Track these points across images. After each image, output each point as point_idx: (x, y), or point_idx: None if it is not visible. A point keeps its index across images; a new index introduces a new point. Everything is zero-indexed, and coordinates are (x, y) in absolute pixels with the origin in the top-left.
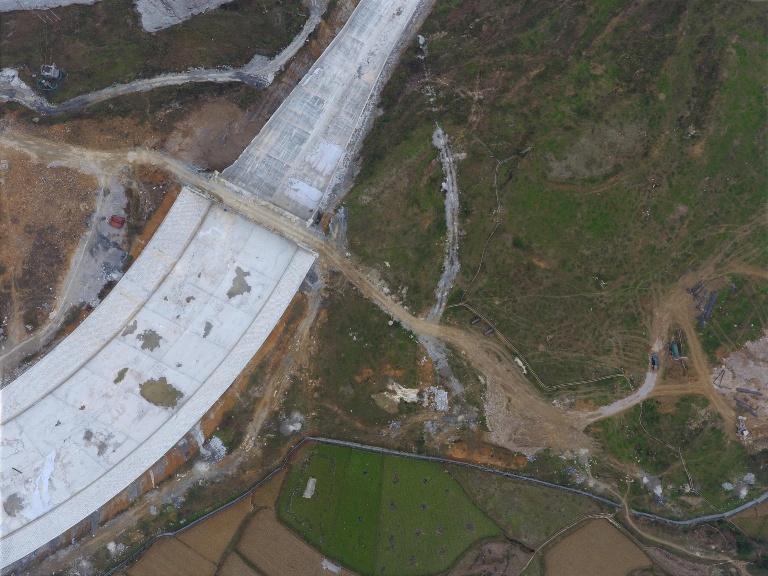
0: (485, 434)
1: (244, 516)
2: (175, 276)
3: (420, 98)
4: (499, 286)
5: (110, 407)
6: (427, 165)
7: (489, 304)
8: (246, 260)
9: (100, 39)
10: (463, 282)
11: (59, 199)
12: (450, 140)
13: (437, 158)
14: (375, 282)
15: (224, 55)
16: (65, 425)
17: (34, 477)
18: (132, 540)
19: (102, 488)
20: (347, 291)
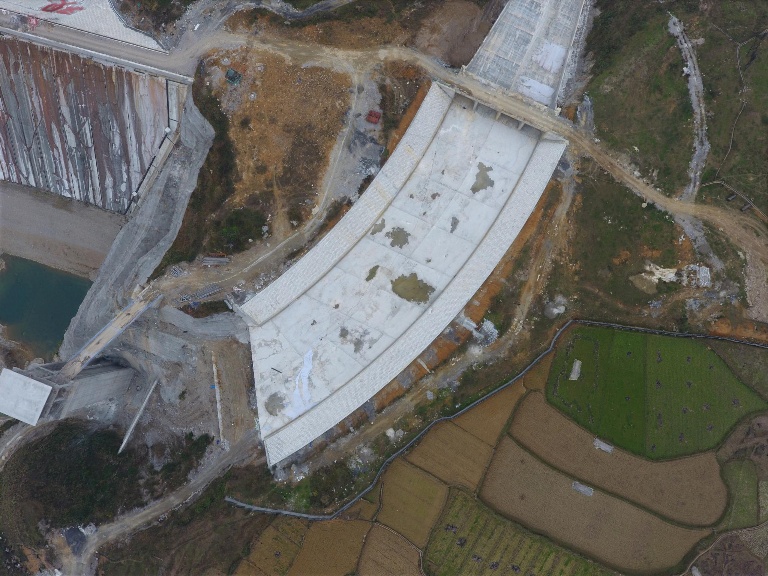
0: (744, 311)
1: (518, 398)
2: (419, 174)
3: None
4: (752, 163)
5: (364, 304)
6: (665, 52)
7: (744, 180)
8: (488, 155)
9: None
10: (715, 161)
11: (315, 98)
12: (686, 27)
13: (675, 45)
14: (626, 166)
15: None
16: (321, 324)
17: (293, 376)
18: (410, 426)
19: (367, 381)
20: (599, 176)
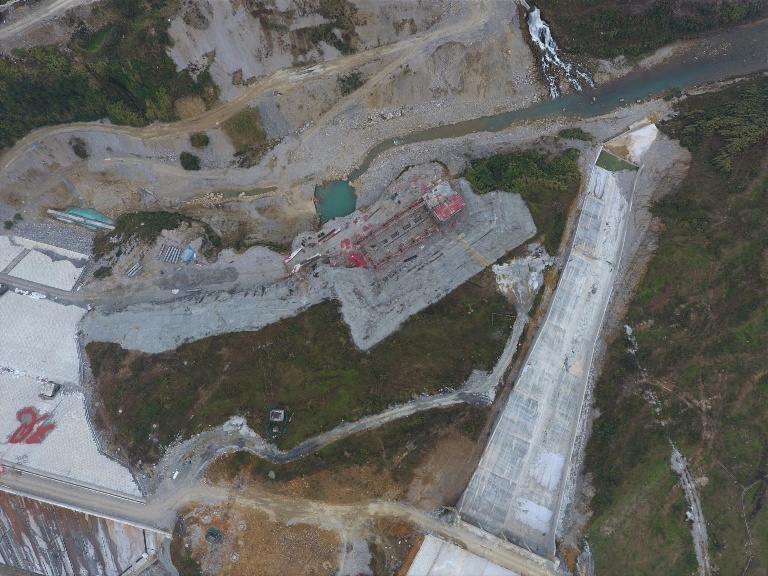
0: None
1: None
2: None
3: (644, 407)
4: None
5: None
6: (668, 491)
7: None
8: None
9: (314, 361)
10: None
11: (301, 559)
12: (689, 463)
13: (678, 484)
14: None
15: (441, 371)
16: None
17: None
18: None
19: None
20: None
